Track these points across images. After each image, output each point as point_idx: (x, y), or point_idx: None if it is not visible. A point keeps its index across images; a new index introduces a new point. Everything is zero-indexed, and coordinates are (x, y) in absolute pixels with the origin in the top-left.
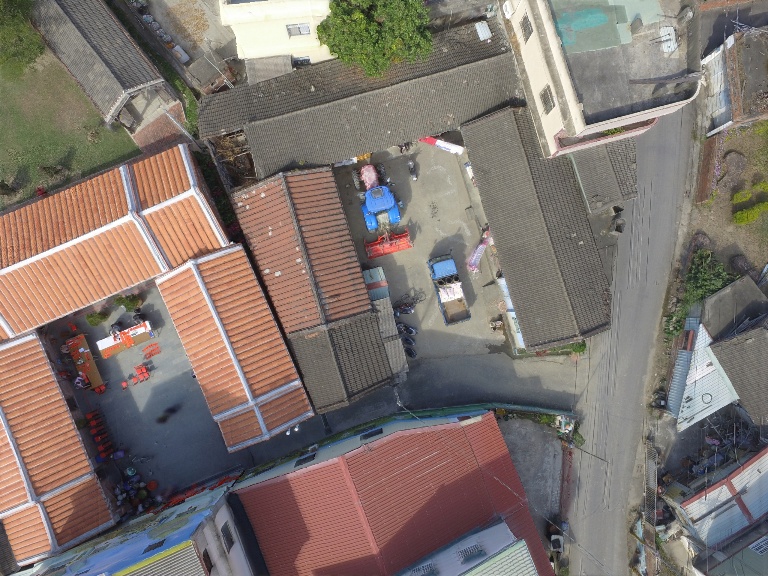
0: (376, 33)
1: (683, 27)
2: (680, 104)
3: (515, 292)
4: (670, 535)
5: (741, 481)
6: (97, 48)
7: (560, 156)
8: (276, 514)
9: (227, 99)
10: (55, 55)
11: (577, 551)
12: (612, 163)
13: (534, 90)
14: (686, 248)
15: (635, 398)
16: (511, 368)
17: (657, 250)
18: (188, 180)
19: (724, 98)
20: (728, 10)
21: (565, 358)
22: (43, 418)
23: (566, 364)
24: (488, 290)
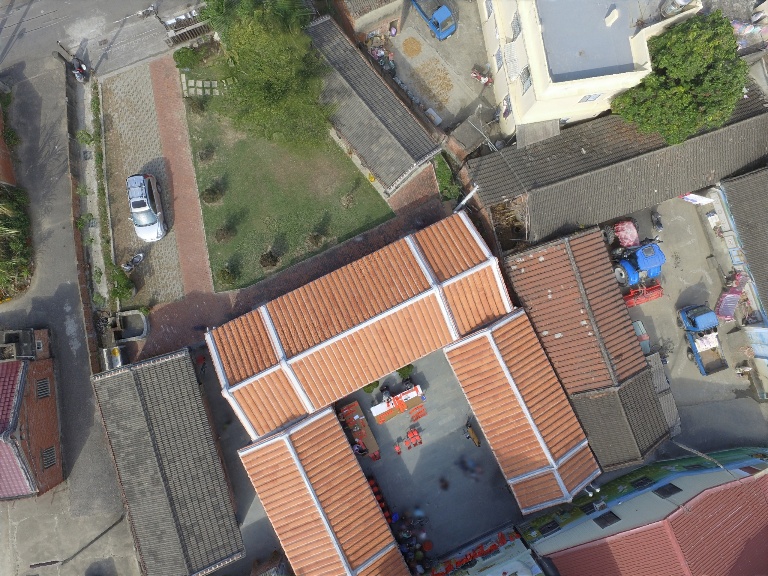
0: (690, 105)
1: None
2: None
3: None
4: None
5: None
6: (383, 121)
7: None
8: None
9: (495, 163)
10: (333, 127)
11: None
12: None
13: None
14: None
15: None
16: (758, 412)
17: None
18: (480, 250)
19: None
20: None
21: None
22: (347, 491)
23: None
24: (734, 337)
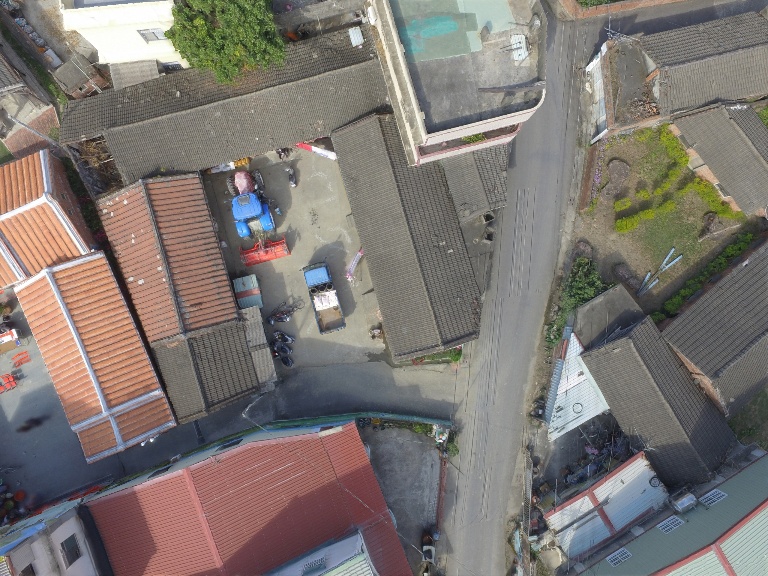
0: (220, 39)
1: (534, 35)
2: (524, 113)
3: (383, 301)
4: (542, 545)
5: (603, 492)
6: None
7: (431, 163)
8: (124, 527)
9: (93, 104)
10: None
11: (454, 561)
12: (479, 171)
13: (398, 97)
14: (569, 256)
15: (515, 407)
16: (390, 377)
17: (540, 258)
18: (43, 187)
19: (604, 105)
20: (614, 17)
21: (445, 367)
22: None
23: (446, 373)
24: (367, 298)
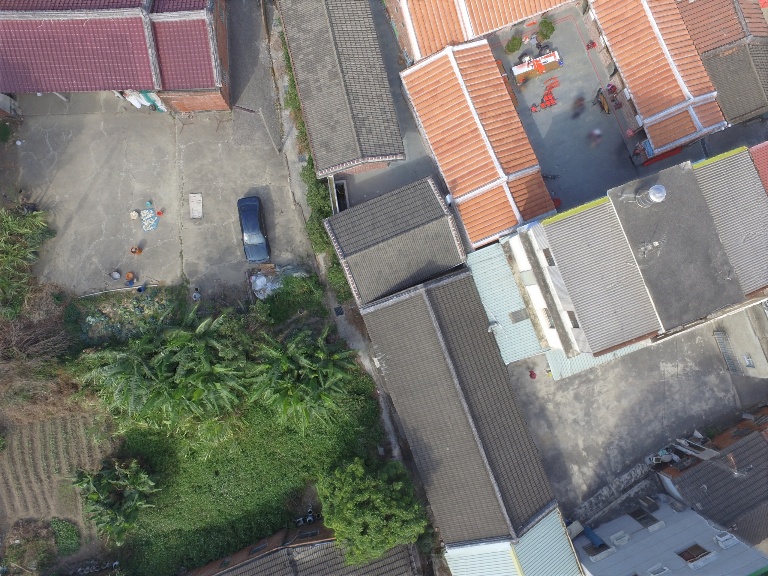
0: None
1: None
2: None
3: None
4: None
5: None
6: None
7: None
8: None
9: None
10: None
11: None
12: None
13: None
14: None
15: None
16: None
17: None
18: None
19: None
20: None
21: None
22: (499, 112)
23: None
24: None
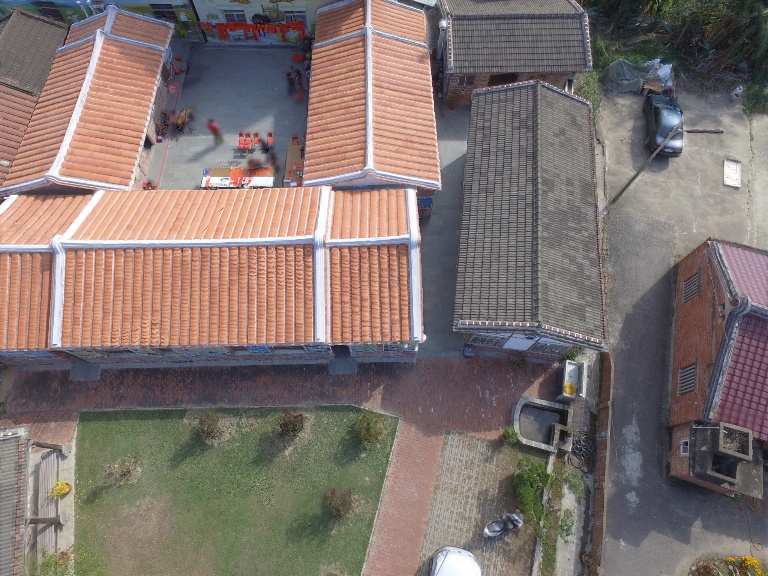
0: None
1: None
2: None
3: None
4: None
5: None
6: None
7: None
8: None
9: None
10: None
11: None
12: None
13: None
14: None
15: None
16: None
17: None
18: None
19: None
20: None
21: None
22: (334, 101)
23: None
24: None
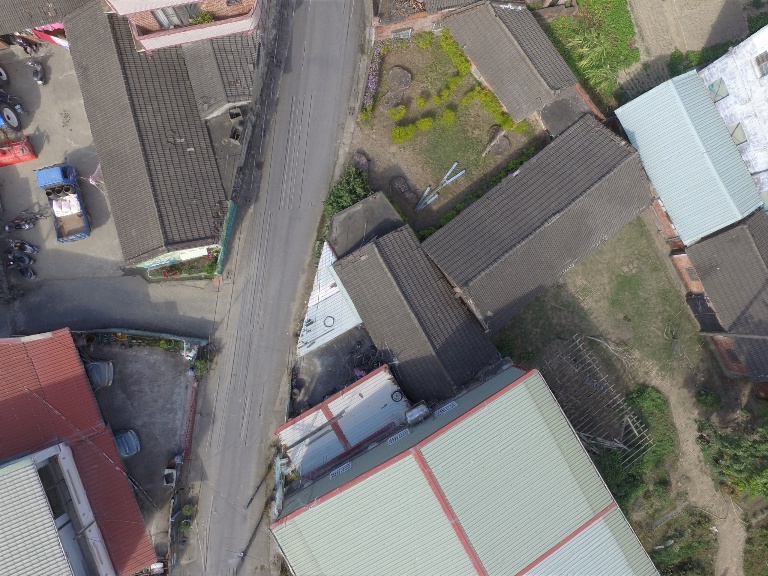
0: None
1: None
2: None
3: (114, 201)
4: (293, 468)
5: (339, 405)
6: None
7: (175, 55)
8: None
9: None
10: None
11: (208, 488)
12: (218, 61)
13: None
14: (345, 168)
15: (281, 326)
16: (145, 292)
17: (314, 170)
18: None
19: None
20: None
21: (207, 283)
22: None
23: (207, 289)
24: None
